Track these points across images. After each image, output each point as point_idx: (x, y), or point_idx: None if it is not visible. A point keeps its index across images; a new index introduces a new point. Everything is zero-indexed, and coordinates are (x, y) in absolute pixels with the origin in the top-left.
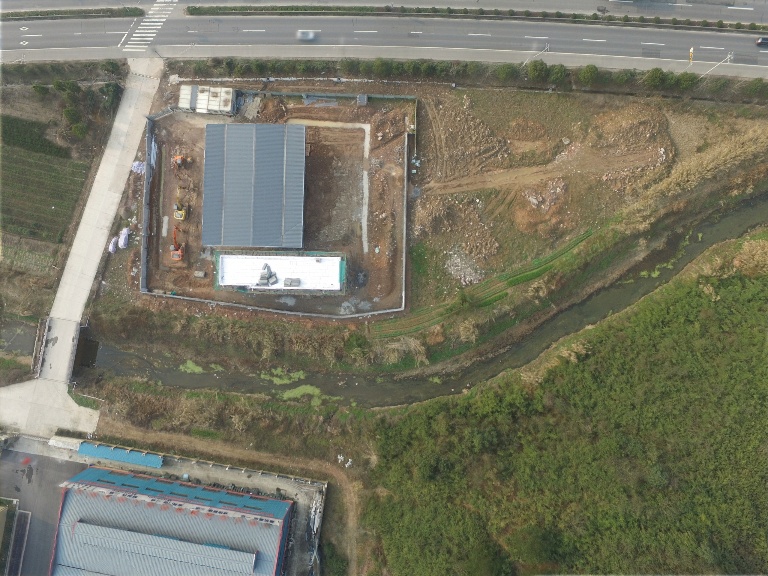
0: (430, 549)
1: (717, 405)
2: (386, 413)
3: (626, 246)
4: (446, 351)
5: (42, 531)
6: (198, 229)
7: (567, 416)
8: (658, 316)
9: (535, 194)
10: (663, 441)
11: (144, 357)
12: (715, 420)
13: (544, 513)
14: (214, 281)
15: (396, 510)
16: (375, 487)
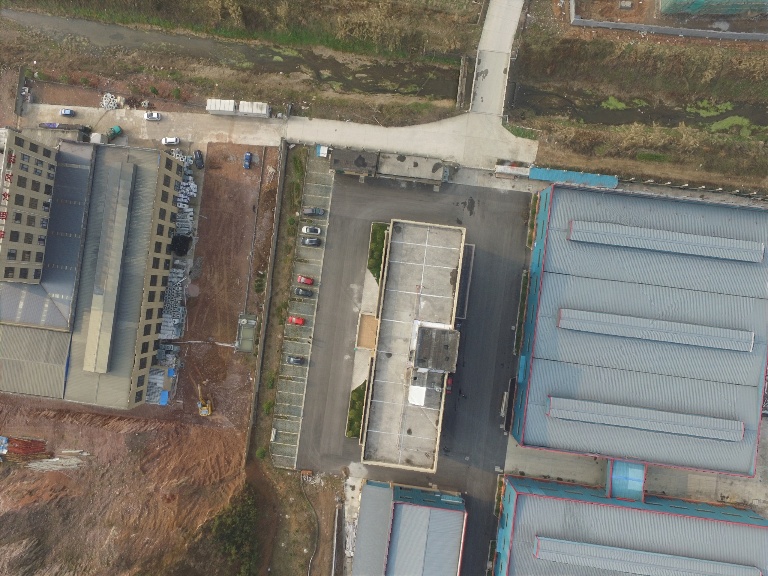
0: None
1: None
2: None
3: None
4: None
5: (488, 262)
6: None
7: None
8: None
9: None
10: None
11: (564, 95)
12: None
13: None
14: (641, 11)
15: None
16: None
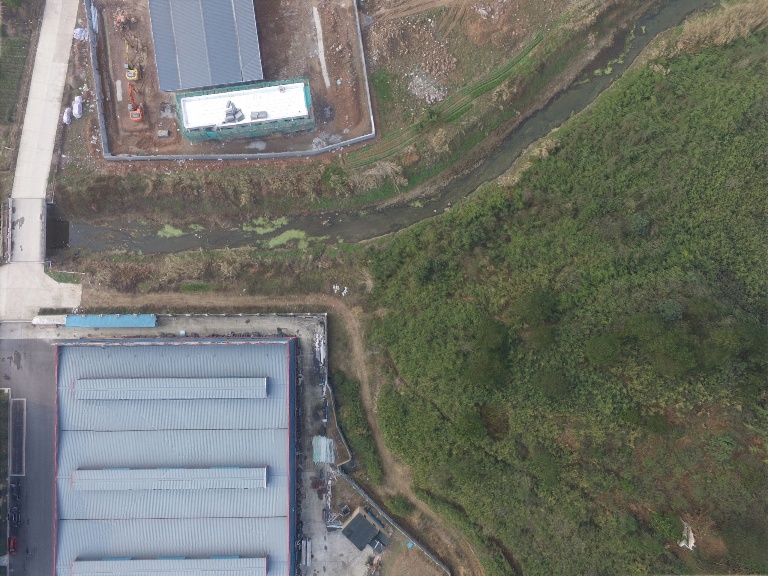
0: (437, 342)
1: (682, 153)
2: (374, 243)
3: (577, 46)
4: (422, 172)
5: (41, 415)
6: (154, 89)
7: (547, 204)
8: (617, 101)
9: (484, 6)
10: (639, 194)
11: (119, 229)
12: (683, 165)
13: (540, 281)
14: (179, 138)
15: (399, 321)
16: (375, 310)
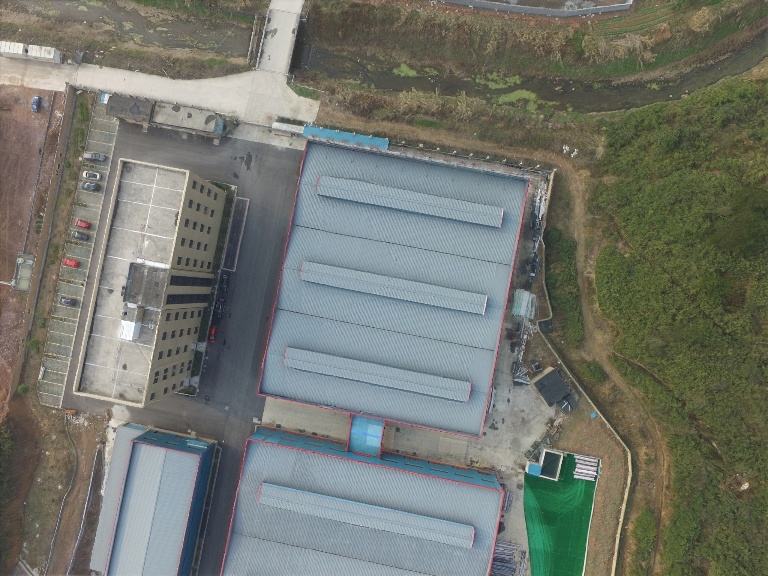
0: (680, 206)
1: None
2: (604, 116)
3: None
4: (668, 54)
5: (260, 217)
6: None
7: None
8: None
9: None
10: None
11: (357, 60)
12: None
13: None
14: None
15: (632, 186)
16: (601, 176)
